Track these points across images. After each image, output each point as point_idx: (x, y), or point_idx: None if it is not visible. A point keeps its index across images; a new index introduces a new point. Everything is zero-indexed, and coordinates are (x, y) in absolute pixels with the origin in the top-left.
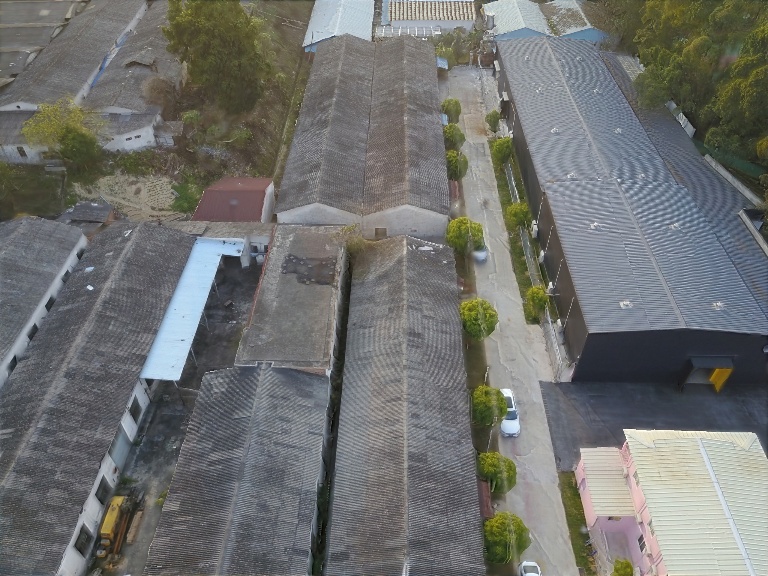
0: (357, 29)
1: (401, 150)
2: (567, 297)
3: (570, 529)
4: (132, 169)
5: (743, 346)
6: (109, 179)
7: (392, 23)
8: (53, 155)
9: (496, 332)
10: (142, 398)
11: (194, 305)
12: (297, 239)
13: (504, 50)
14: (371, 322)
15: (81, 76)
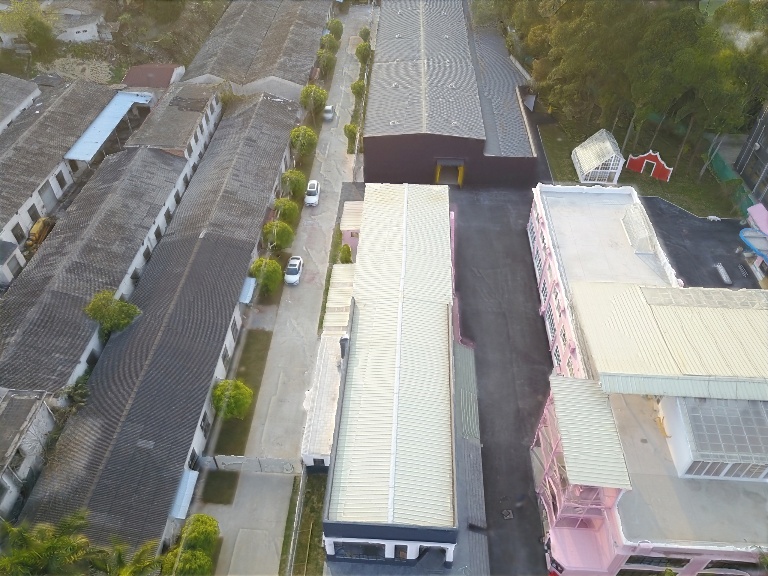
0: None
1: (281, 46)
2: None
3: (332, 247)
4: (80, 54)
5: (469, 150)
6: (62, 60)
7: None
8: (21, 40)
9: (323, 157)
10: (67, 176)
11: (108, 126)
12: (185, 89)
13: None
14: (226, 136)
15: None
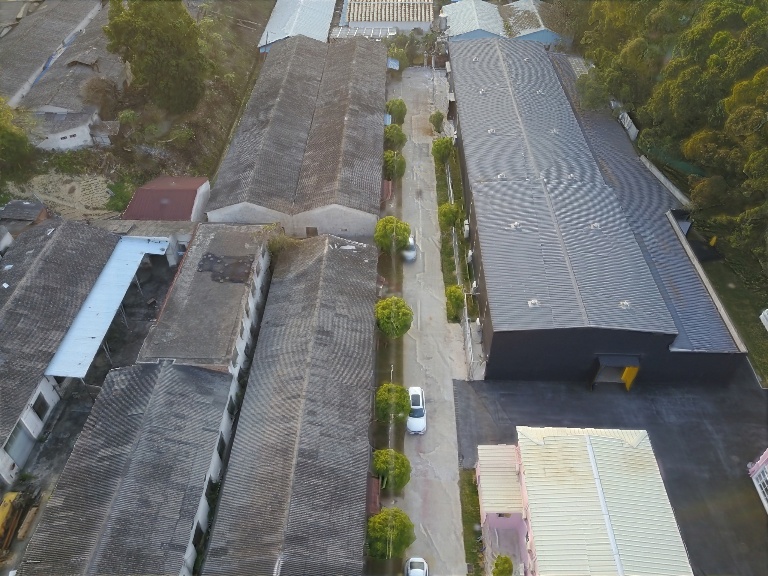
0: (313, 30)
1: (337, 150)
2: (484, 296)
3: (464, 526)
4: (66, 168)
5: (648, 345)
6: (43, 178)
7: (350, 24)
8: None
9: (416, 331)
10: (50, 395)
11: (110, 303)
12: (218, 238)
13: (454, 51)
14: (283, 320)
15: (22, 75)
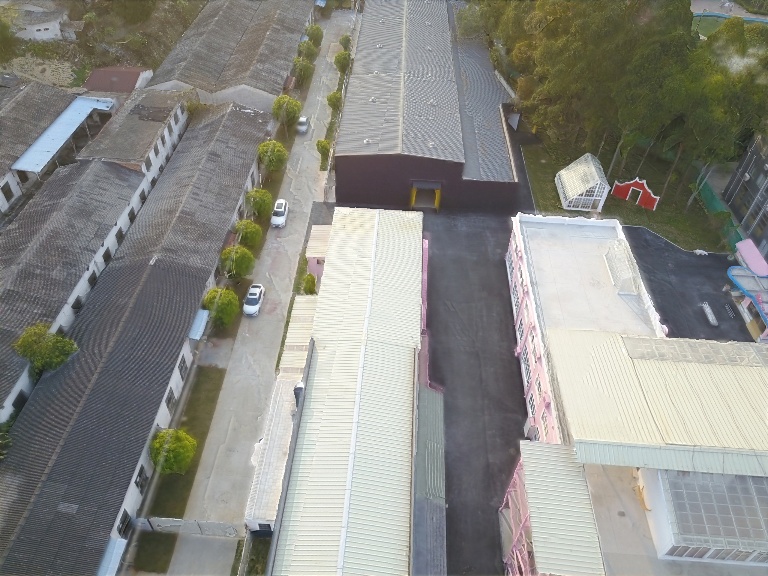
0: None
1: (255, 52)
2: None
3: (297, 274)
4: (40, 53)
5: (447, 173)
6: (21, 60)
7: None
8: None
9: (294, 174)
10: (14, 187)
11: (63, 134)
12: (148, 96)
13: None
14: (189, 149)
15: None
